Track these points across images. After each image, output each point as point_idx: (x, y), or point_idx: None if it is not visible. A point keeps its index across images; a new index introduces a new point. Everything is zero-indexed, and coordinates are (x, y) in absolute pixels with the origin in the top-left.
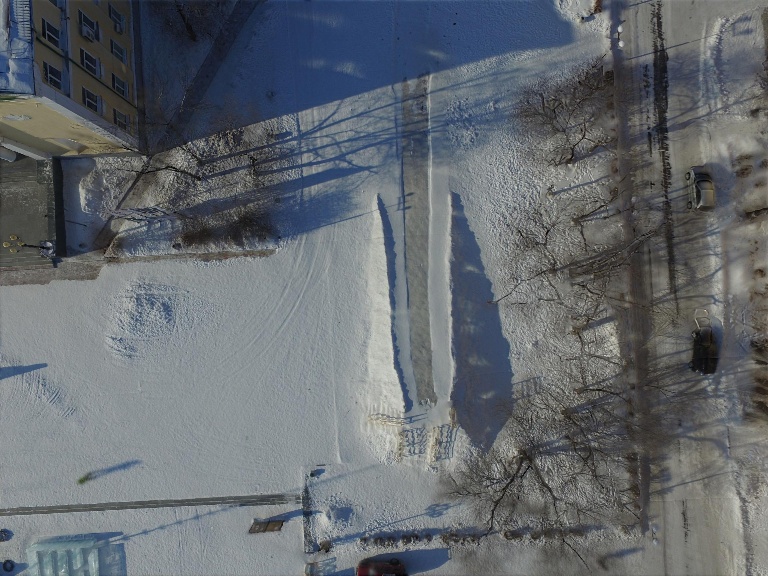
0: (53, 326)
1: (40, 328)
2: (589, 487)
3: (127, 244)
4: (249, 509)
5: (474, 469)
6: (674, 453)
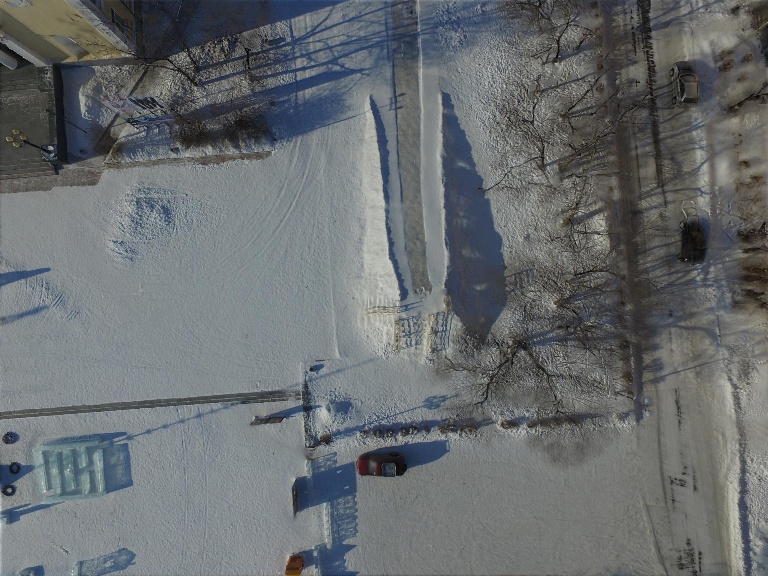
0: (55, 231)
1: (43, 234)
2: (583, 376)
3: (127, 149)
4: (250, 407)
5: (470, 360)
6: (666, 343)
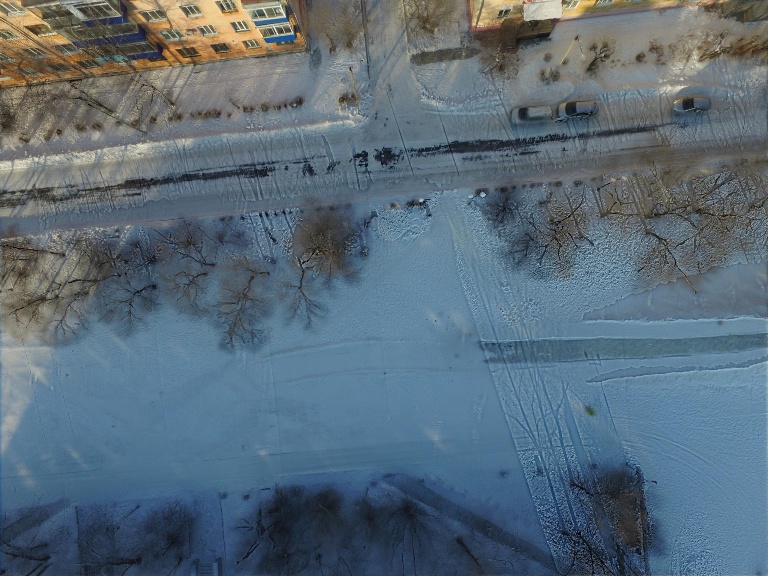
0: None
1: None
2: None
3: None
4: None
5: None
6: None
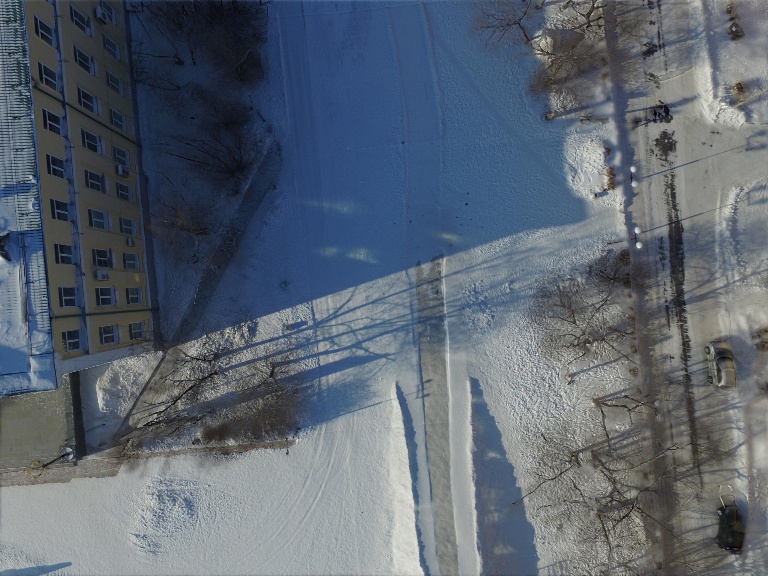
0: (76, 524)
1: (63, 527)
2: None
3: (146, 442)
4: None
5: None
6: None
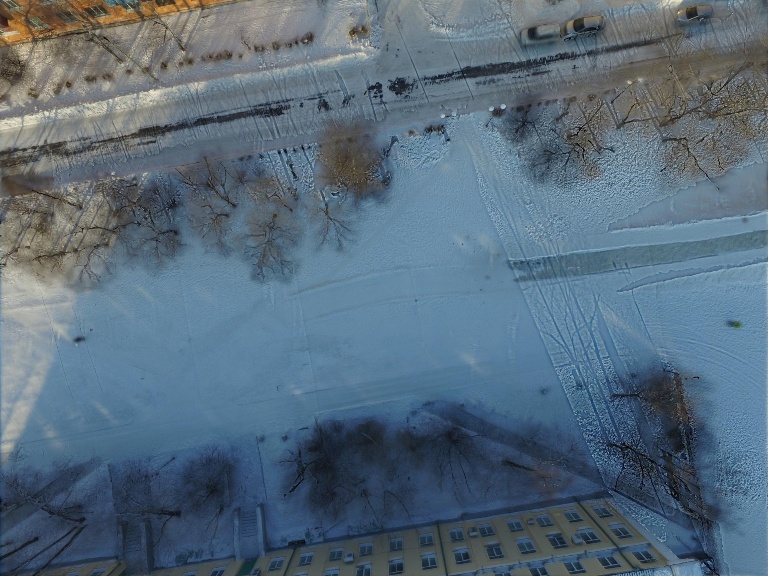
0: (764, 556)
1: (767, 567)
2: None
3: None
4: None
5: None
6: None
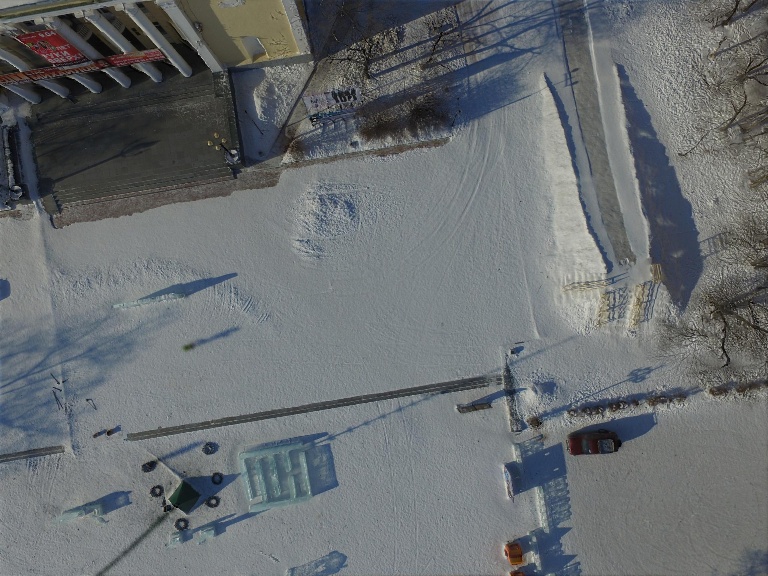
0: (239, 236)
1: (226, 239)
2: None
3: (305, 147)
4: (450, 396)
5: None
6: None
